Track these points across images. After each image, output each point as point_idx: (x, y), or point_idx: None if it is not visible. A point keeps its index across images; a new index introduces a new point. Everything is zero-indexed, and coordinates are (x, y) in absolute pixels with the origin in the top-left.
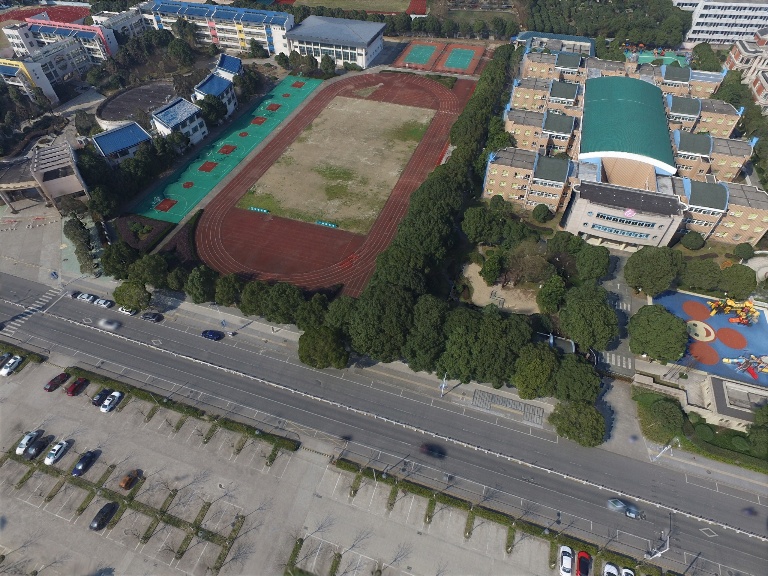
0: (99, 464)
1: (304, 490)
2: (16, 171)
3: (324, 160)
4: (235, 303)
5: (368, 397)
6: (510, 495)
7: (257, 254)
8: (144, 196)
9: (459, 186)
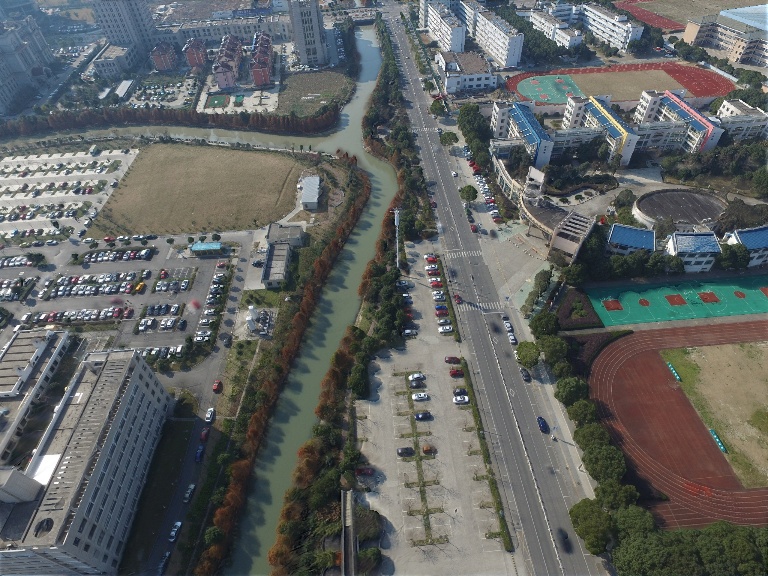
0: (427, 425)
1: None
2: (551, 215)
3: None
4: None
5: None
6: None
7: (632, 404)
8: (606, 286)
9: None
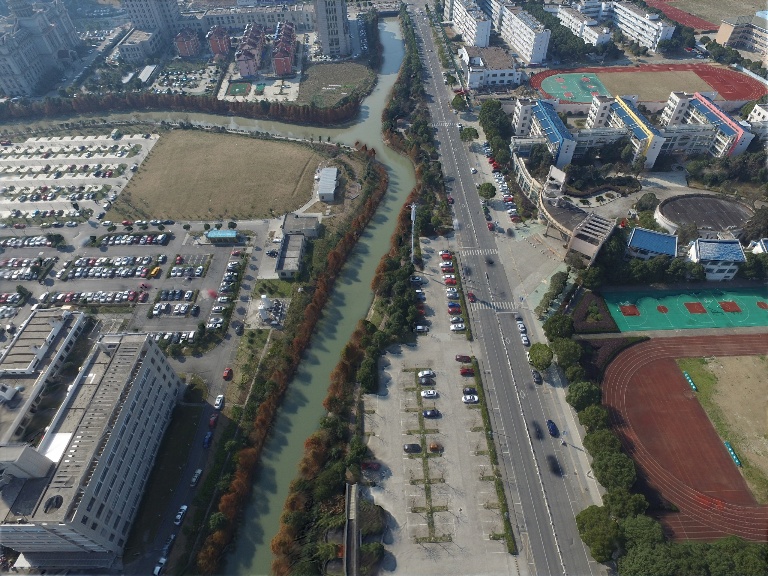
0: (435, 422)
1: None
2: (570, 216)
3: None
4: (588, 427)
5: None
6: None
7: (645, 412)
8: (624, 290)
9: None
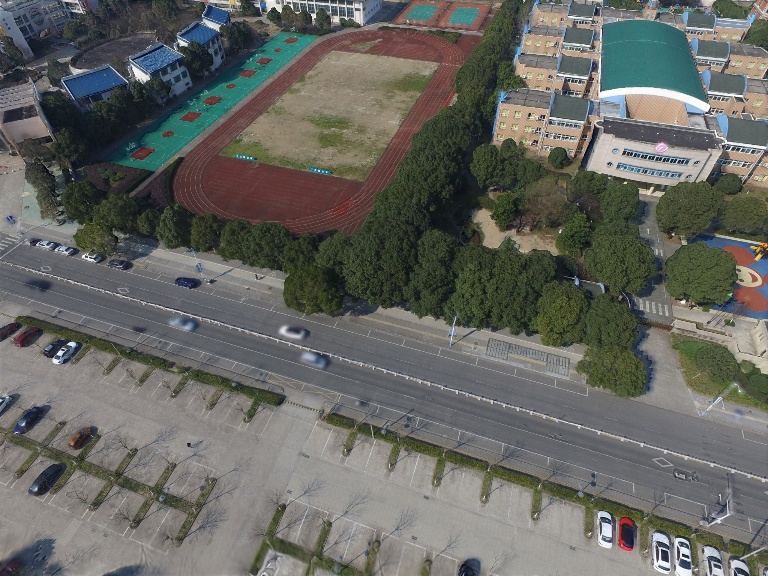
0: (46, 421)
1: (288, 449)
2: None
3: (318, 110)
4: (214, 249)
5: (365, 347)
6: (534, 454)
7: (241, 201)
8: (119, 145)
9: (466, 128)
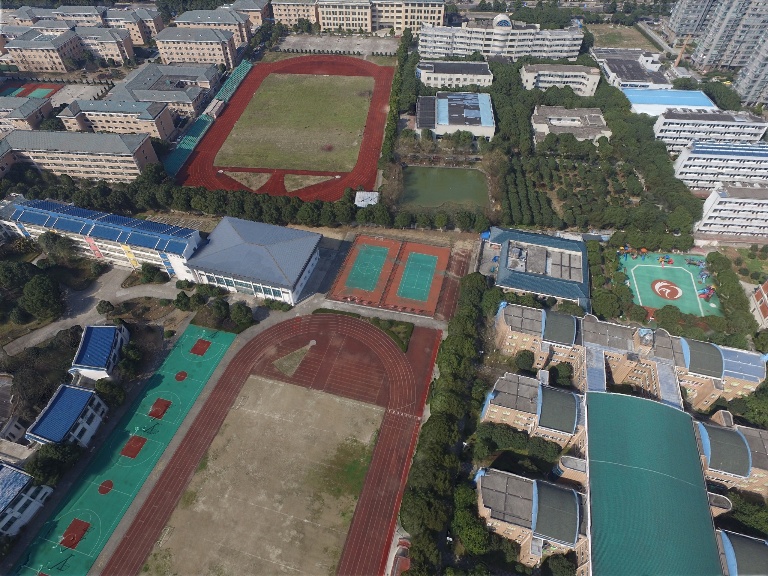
0: None
1: None
2: None
3: (216, 560)
4: None
5: None
6: None
7: None
8: None
9: None
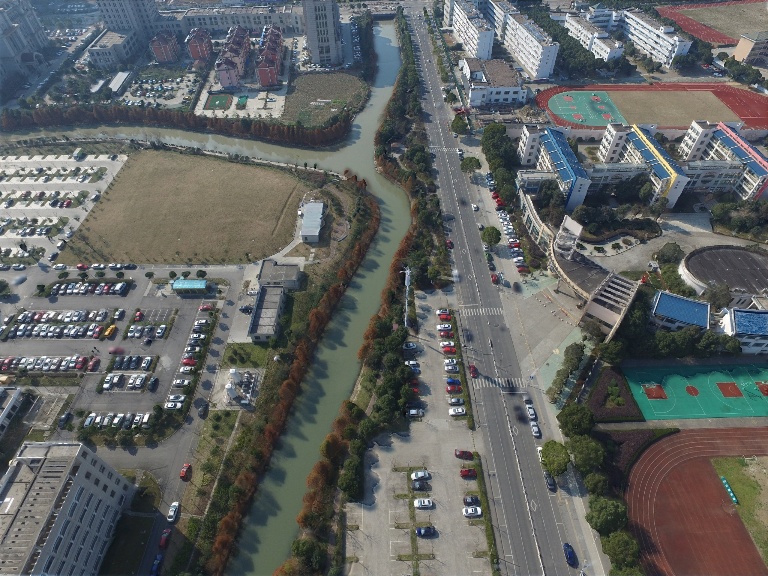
0: (430, 544)
1: None
2: (586, 272)
3: None
4: None
5: None
6: None
7: (679, 532)
8: (647, 365)
9: None
